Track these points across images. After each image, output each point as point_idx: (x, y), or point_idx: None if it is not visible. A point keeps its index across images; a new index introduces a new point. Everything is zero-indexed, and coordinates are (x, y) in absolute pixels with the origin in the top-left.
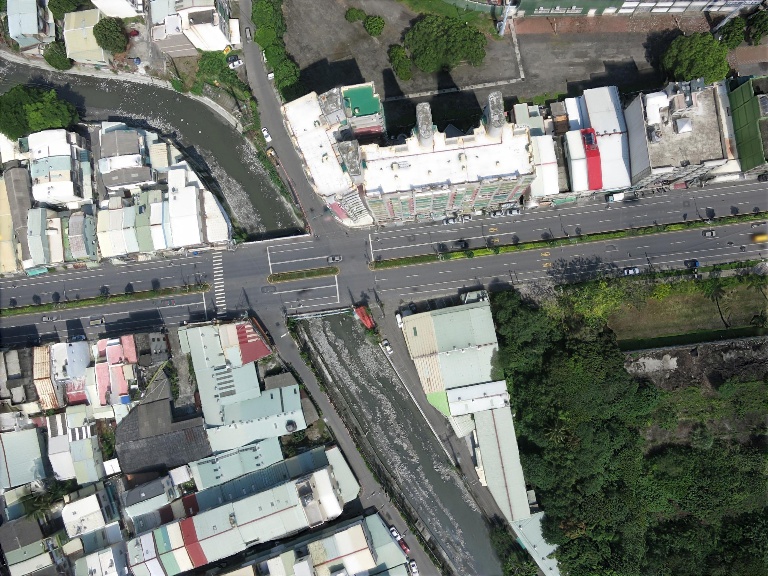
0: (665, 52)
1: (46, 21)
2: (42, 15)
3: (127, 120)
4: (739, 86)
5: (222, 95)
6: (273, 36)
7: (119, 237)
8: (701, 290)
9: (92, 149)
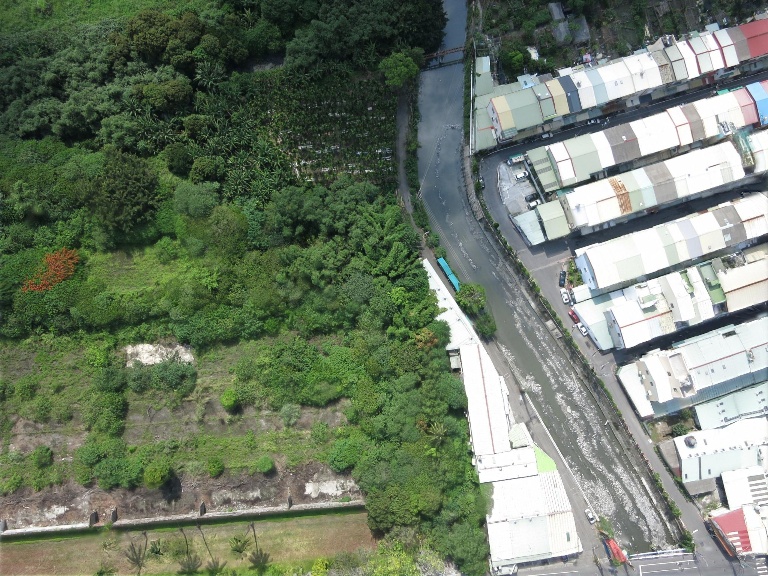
0: None
1: None
2: None
3: None
4: None
5: None
6: None
7: None
8: (280, 570)
9: None
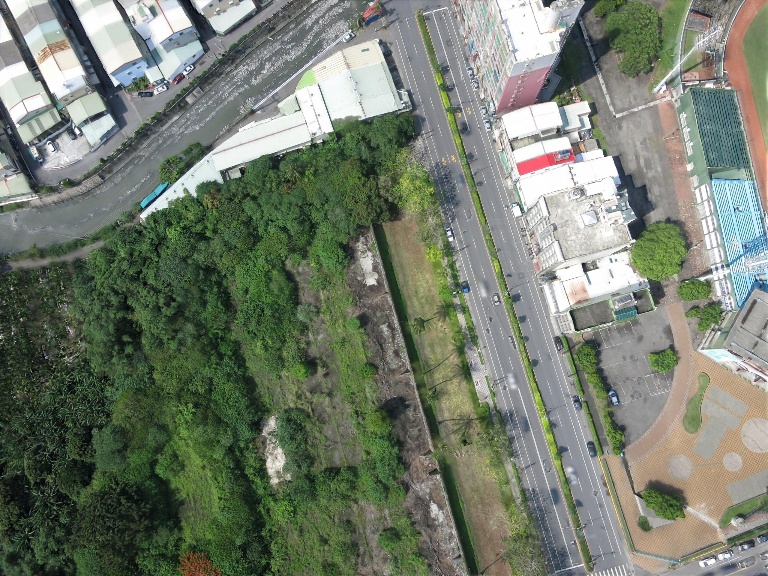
0: None
1: None
2: None
3: None
4: None
5: None
6: None
7: None
8: None
9: None
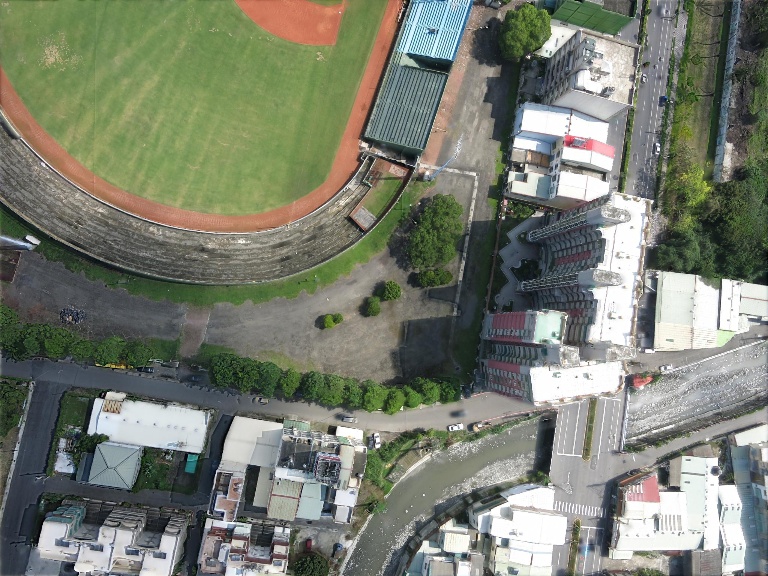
0: (506, 51)
1: None
2: None
3: (388, 571)
4: (559, 8)
5: (401, 463)
6: (402, 394)
7: None
8: None
9: None
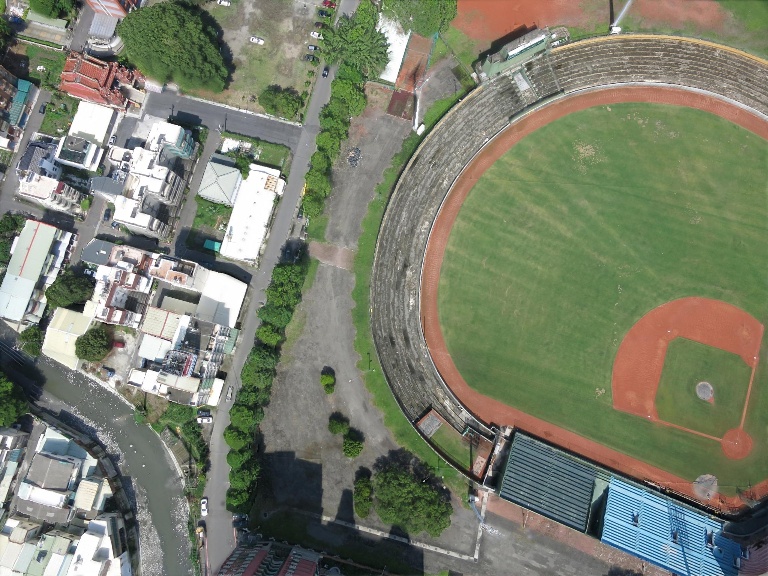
0: None
1: (38, 300)
2: (36, 297)
3: (78, 422)
4: None
5: (179, 443)
6: None
7: (6, 575)
8: None
9: (28, 443)
